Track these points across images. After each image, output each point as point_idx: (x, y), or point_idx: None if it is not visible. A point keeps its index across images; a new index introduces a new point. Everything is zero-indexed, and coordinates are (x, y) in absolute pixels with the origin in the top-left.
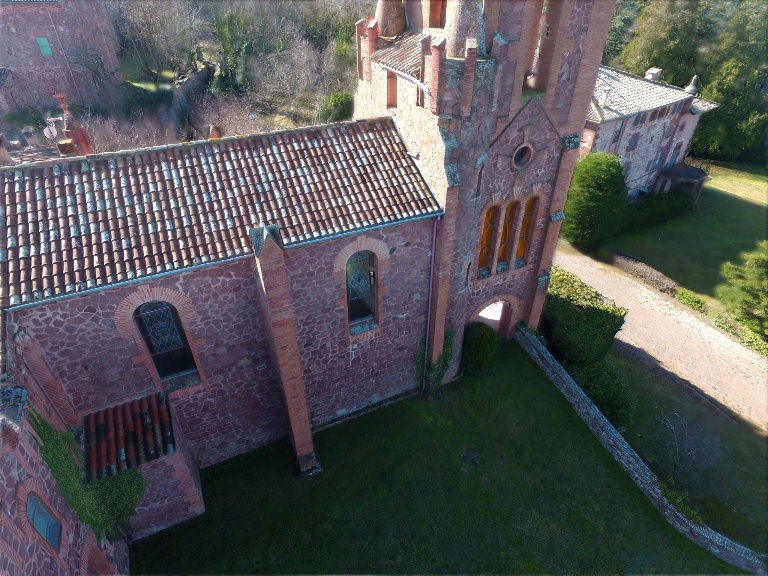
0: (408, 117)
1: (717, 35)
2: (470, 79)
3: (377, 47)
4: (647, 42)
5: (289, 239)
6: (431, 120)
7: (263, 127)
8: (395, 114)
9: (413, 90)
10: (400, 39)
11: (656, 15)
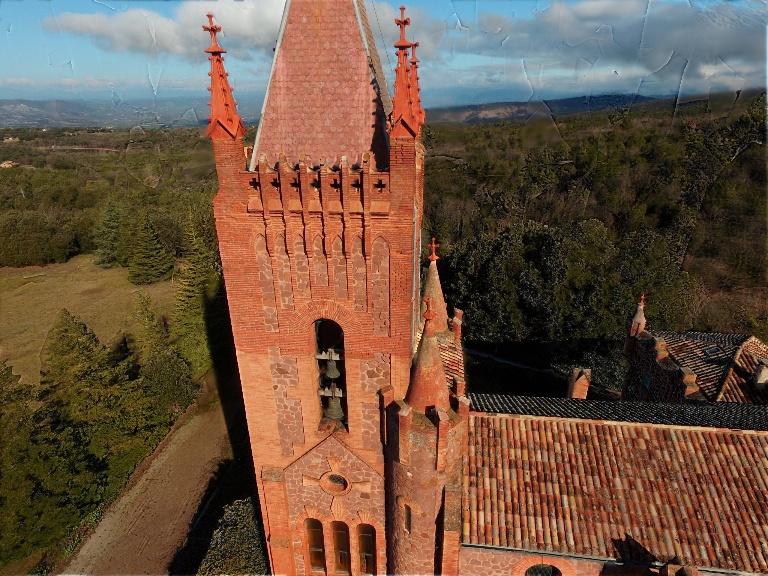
0: None
1: None
2: None
3: None
4: None
5: None
6: None
7: None
8: None
9: None
10: None
11: None
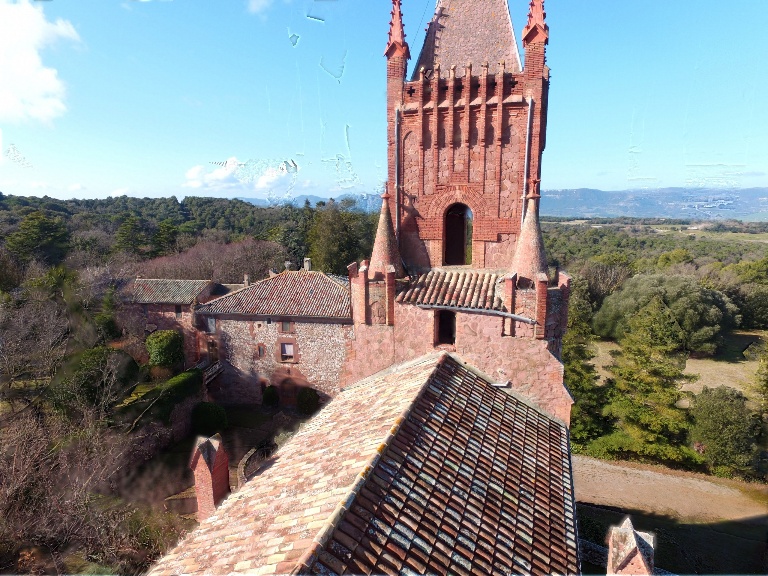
0: (484, 349)
1: (369, 246)
2: (567, 303)
3: (396, 290)
4: (325, 255)
5: (568, 538)
6: (534, 346)
7: (5, 426)
8: (454, 350)
9: (495, 323)
10: (414, 279)
11: (325, 236)
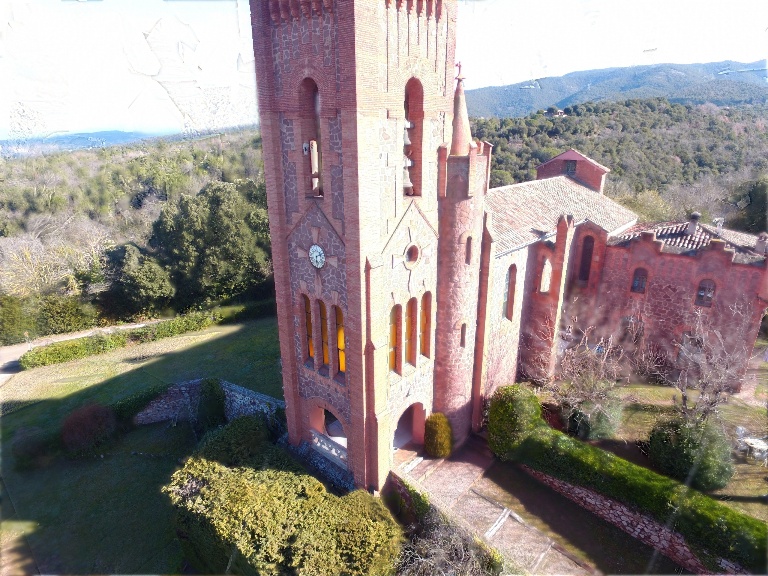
0: None
1: None
2: None
3: None
4: None
5: None
6: None
7: None
8: None
9: None
10: None
11: None
